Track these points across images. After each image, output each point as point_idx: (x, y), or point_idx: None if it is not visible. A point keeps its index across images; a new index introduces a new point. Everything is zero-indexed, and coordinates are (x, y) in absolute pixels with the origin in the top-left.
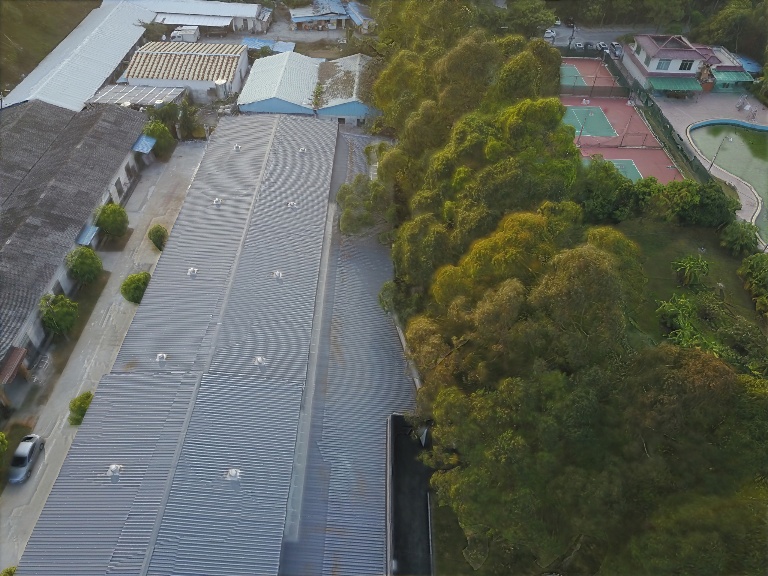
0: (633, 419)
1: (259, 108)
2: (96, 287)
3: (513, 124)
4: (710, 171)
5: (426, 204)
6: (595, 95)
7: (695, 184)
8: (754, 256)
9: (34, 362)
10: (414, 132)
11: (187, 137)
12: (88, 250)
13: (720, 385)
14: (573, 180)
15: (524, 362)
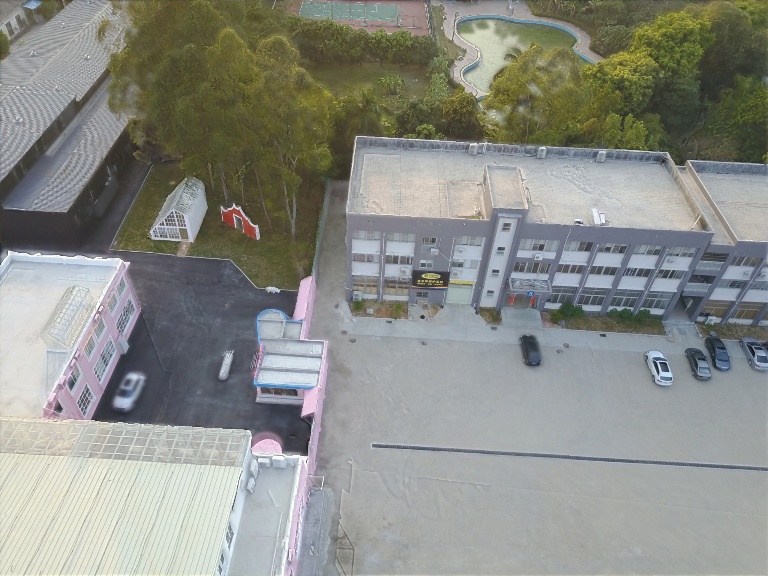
0: None
1: None
2: None
3: None
4: (454, 41)
5: None
6: None
7: (409, 33)
8: (433, 75)
9: None
10: None
11: None
12: None
13: None
14: None
15: None
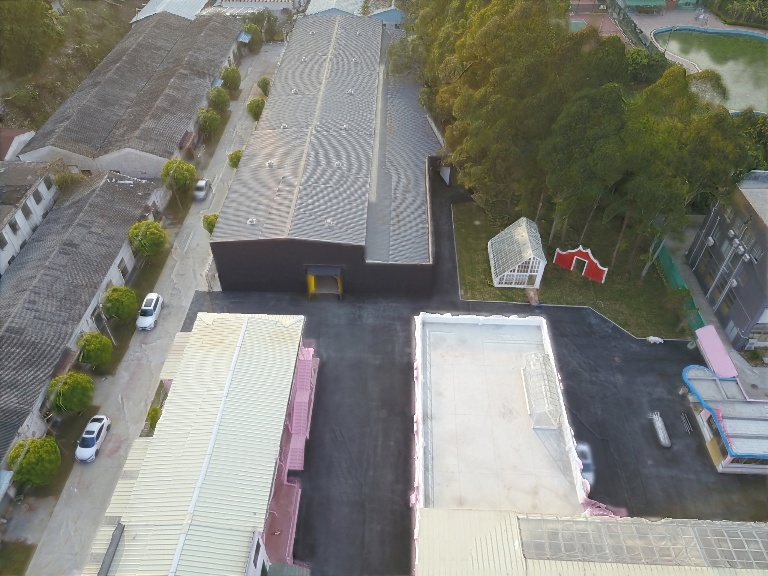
0: (551, 61)
1: None
2: (224, 117)
3: None
4: (665, 56)
5: None
6: (580, 12)
7: (644, 51)
8: None
9: (196, 149)
10: None
11: (269, 40)
12: (221, 88)
13: (589, 32)
14: None
15: None
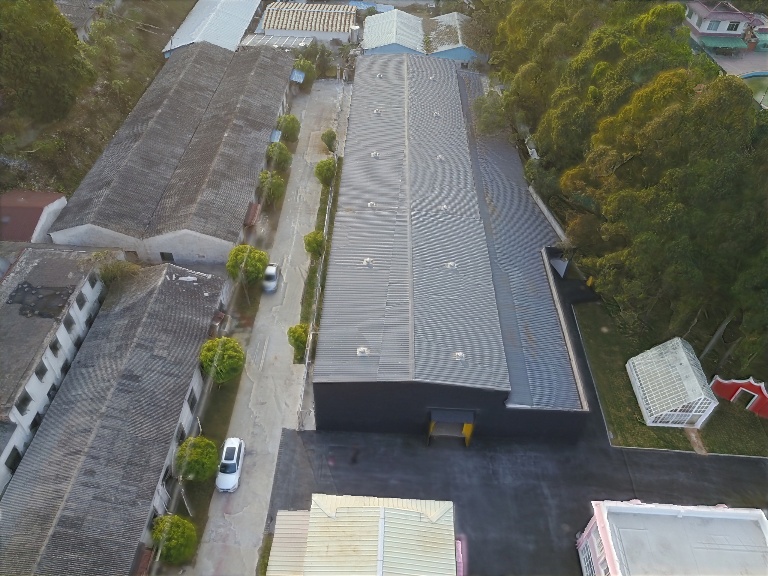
0: (765, 172)
1: (380, 52)
2: (284, 176)
3: (649, 22)
4: None
5: (566, 95)
6: None
7: None
8: None
9: None
10: (550, 47)
11: (321, 76)
12: None
13: None
14: None
15: (675, 166)
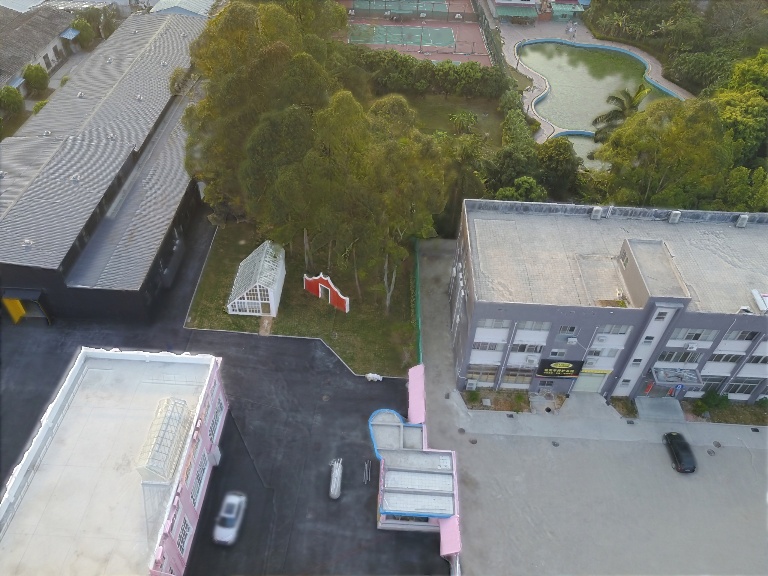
0: (245, 78)
1: None
2: (21, 119)
3: None
4: (518, 69)
5: None
6: (451, 20)
7: (478, 64)
8: (509, 111)
9: None
10: None
11: None
12: (13, 88)
13: (276, 50)
14: (295, 3)
15: None
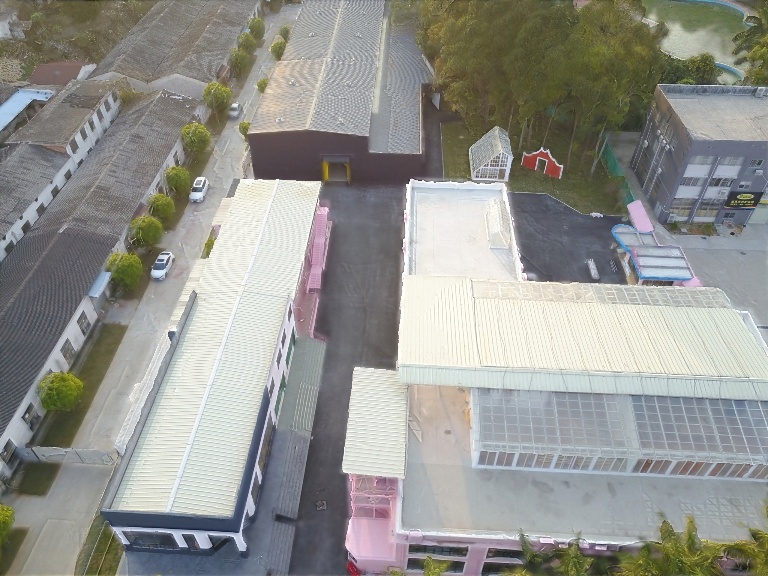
0: None
1: None
2: (251, 60)
3: None
4: None
5: None
6: None
7: None
8: None
9: (229, 81)
10: None
11: (288, 2)
12: None
13: None
14: None
15: None
